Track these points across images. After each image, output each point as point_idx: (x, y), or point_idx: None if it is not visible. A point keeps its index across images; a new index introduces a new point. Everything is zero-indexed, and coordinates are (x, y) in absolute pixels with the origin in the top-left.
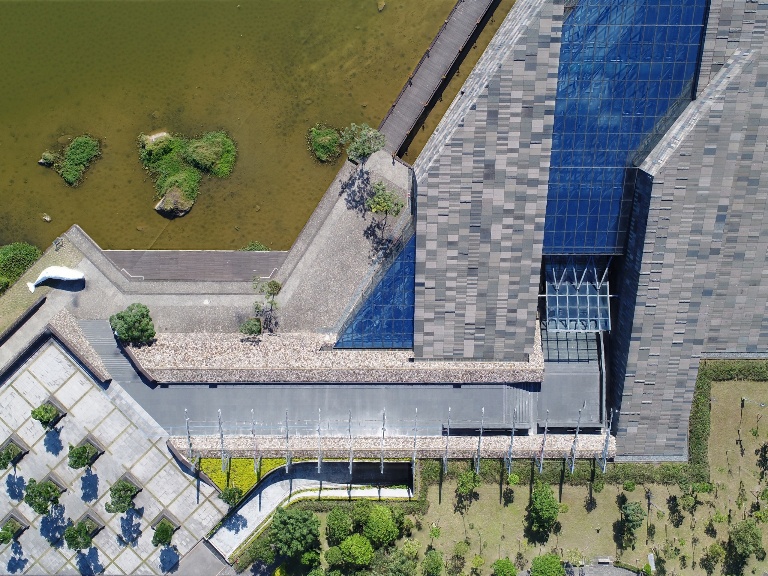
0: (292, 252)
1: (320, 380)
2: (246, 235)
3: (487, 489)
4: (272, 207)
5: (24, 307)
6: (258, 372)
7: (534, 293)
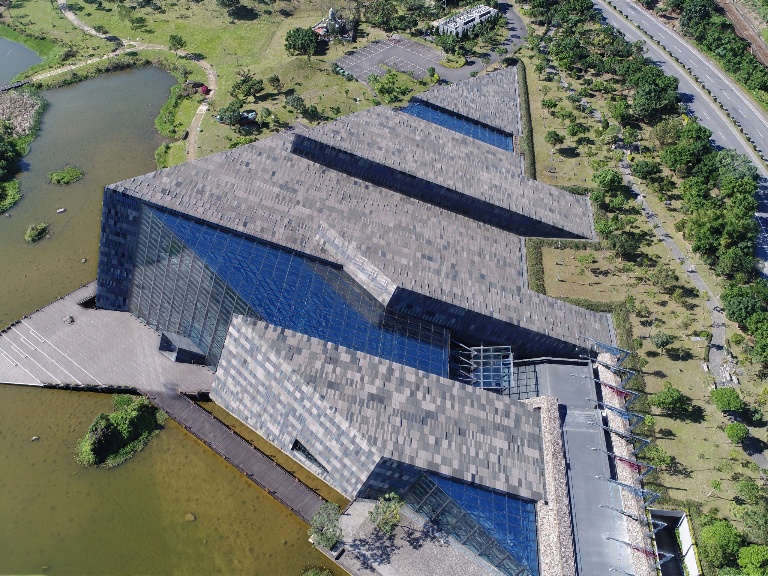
0: None
1: None
2: None
3: None
4: None
5: None
6: None
7: (481, 392)
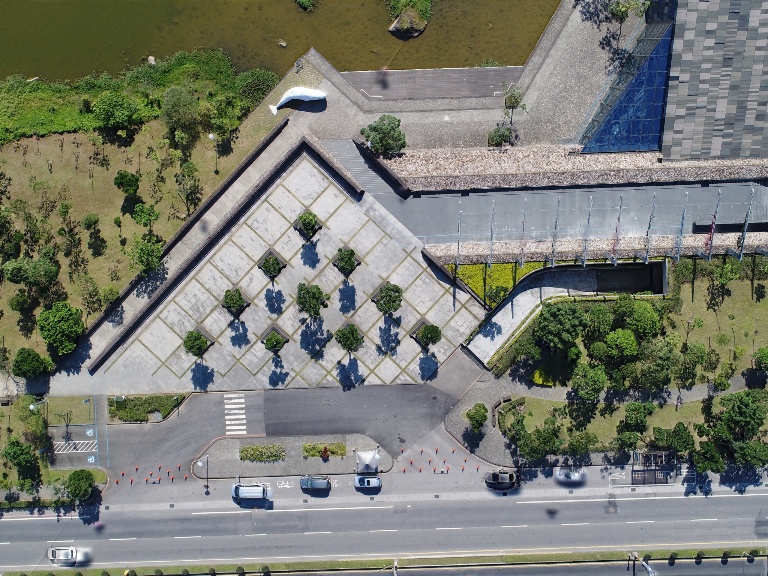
0: (528, 66)
1: (571, 183)
2: (480, 53)
3: (739, 285)
4: (504, 24)
5: (267, 130)
6: (511, 177)
7: None
